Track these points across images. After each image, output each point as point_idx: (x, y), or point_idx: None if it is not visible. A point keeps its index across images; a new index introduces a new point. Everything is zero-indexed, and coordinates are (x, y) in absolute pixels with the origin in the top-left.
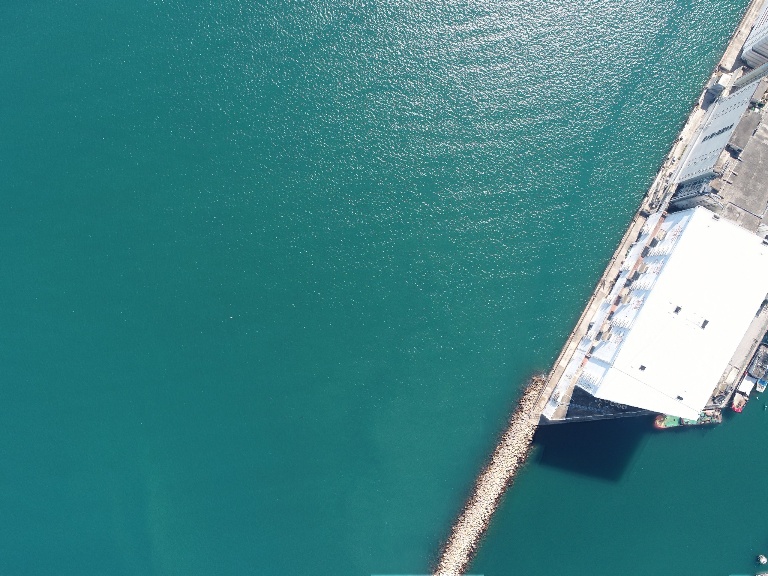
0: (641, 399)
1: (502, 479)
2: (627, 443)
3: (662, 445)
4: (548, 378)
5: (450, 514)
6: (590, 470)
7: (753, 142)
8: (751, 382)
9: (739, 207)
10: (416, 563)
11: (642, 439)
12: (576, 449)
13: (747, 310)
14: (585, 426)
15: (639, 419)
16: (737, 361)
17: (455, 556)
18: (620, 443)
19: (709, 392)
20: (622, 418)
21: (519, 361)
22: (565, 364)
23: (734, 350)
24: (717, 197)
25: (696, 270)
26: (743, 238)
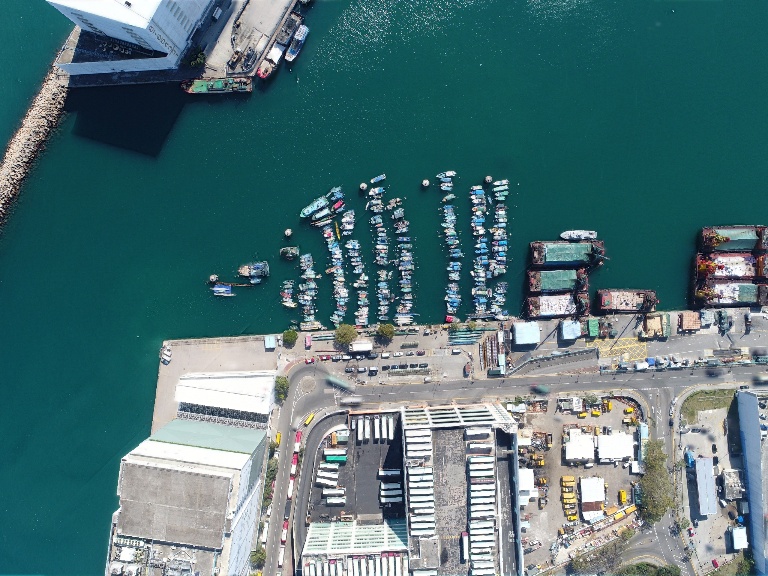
0: (90, 4)
1: (30, 141)
2: (160, 112)
3: (193, 113)
4: None
5: None
6: (123, 138)
7: None
8: (278, 49)
9: None
10: None
11: (175, 108)
12: (107, 114)
13: None
14: (115, 90)
15: (169, 85)
16: (267, 29)
17: None
18: (153, 112)
19: None
20: (154, 84)
21: (53, 22)
22: None
23: None
24: None
25: None
26: None
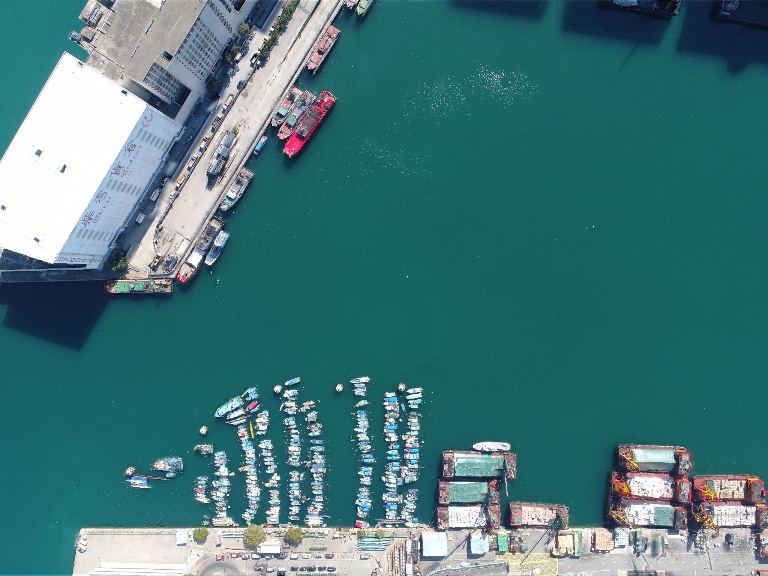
0: (2, 238)
1: None
2: (86, 307)
3: (116, 311)
4: None
5: None
6: (49, 331)
7: None
8: (198, 254)
9: (103, 55)
10: None
11: (100, 304)
12: (34, 309)
13: (104, 157)
14: (43, 287)
15: (94, 283)
16: (189, 233)
17: None
18: (79, 307)
19: (65, 236)
20: (80, 282)
21: None
22: None
23: (91, 196)
24: (90, 46)
25: (57, 114)
26: (105, 86)
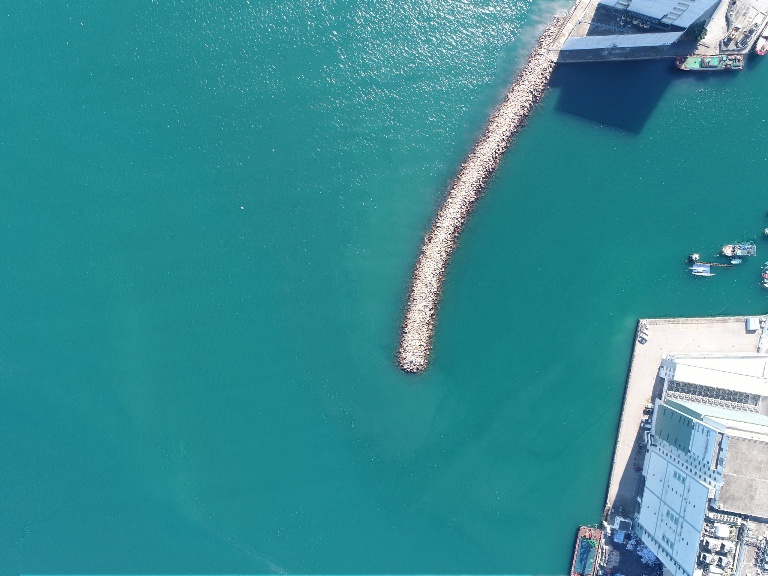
0: None
1: (516, 116)
2: (645, 88)
3: (681, 90)
4: (570, 12)
5: (460, 153)
6: (605, 114)
7: None
8: None
9: None
10: (422, 201)
11: (661, 85)
12: (593, 90)
13: None
14: (604, 66)
15: (659, 61)
16: (763, 6)
17: (463, 190)
18: (638, 88)
19: None
20: (642, 61)
21: None
22: (588, 0)
23: None
24: None
25: None
26: None
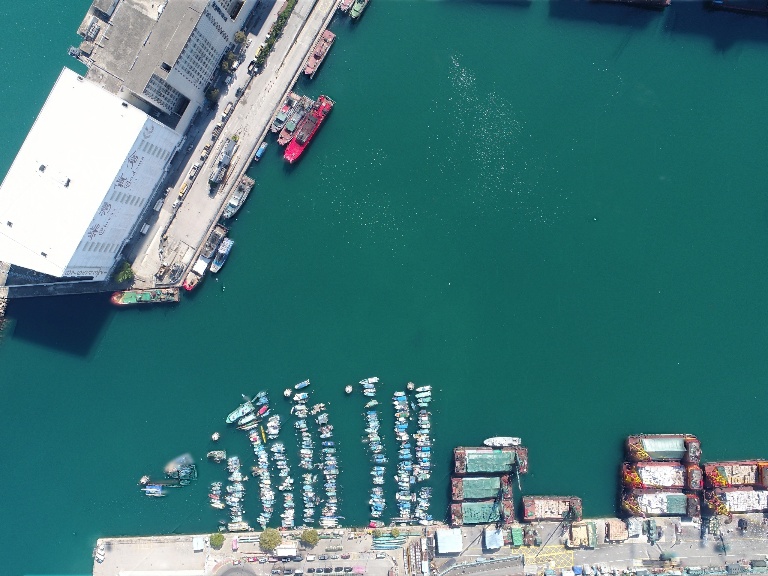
0: (9, 254)
1: None
2: (94, 319)
3: (124, 322)
4: None
5: None
6: (59, 344)
7: (124, 7)
8: (204, 262)
9: (102, 69)
10: None
11: (108, 316)
12: (43, 323)
13: (107, 170)
14: (51, 300)
15: (101, 295)
16: (193, 241)
17: None
18: (88, 319)
19: (72, 249)
20: (87, 294)
21: None
22: None
23: (96, 209)
24: (89, 60)
25: (59, 129)
26: (105, 100)
